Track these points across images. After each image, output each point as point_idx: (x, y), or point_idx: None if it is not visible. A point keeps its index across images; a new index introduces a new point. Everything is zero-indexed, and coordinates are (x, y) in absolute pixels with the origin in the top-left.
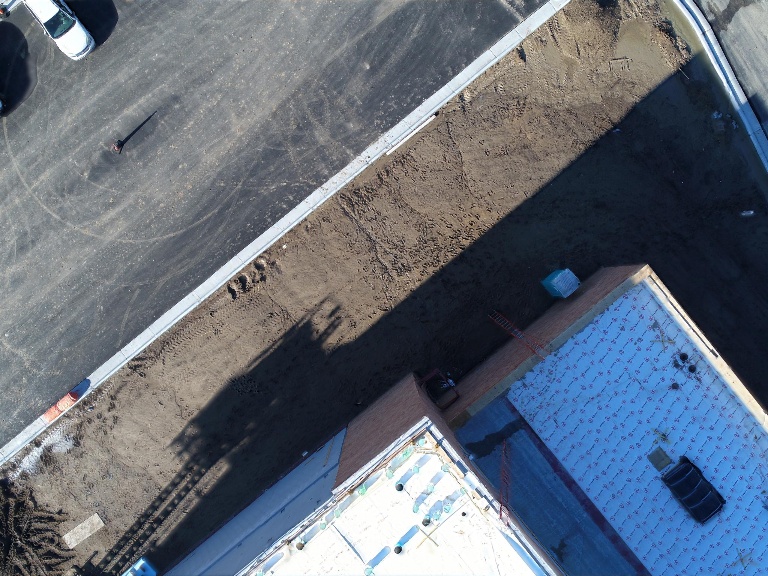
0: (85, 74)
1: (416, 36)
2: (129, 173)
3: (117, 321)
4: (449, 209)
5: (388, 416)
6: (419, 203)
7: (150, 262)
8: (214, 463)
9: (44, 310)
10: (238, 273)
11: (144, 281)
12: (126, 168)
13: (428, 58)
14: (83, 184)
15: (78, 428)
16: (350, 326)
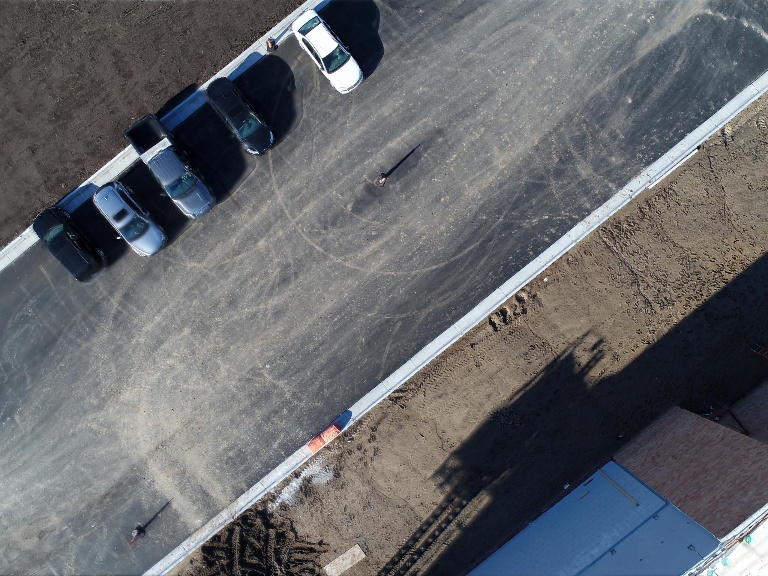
0: (350, 107)
1: (678, 70)
2: (392, 206)
3: (379, 353)
4: (712, 243)
5: (708, 456)
6: (682, 237)
7: (412, 294)
8: (475, 495)
9: (305, 342)
10: (499, 306)
11: (406, 313)
12: (389, 201)
13: (690, 92)
14: (346, 216)
15: (338, 459)
16: (613, 359)
